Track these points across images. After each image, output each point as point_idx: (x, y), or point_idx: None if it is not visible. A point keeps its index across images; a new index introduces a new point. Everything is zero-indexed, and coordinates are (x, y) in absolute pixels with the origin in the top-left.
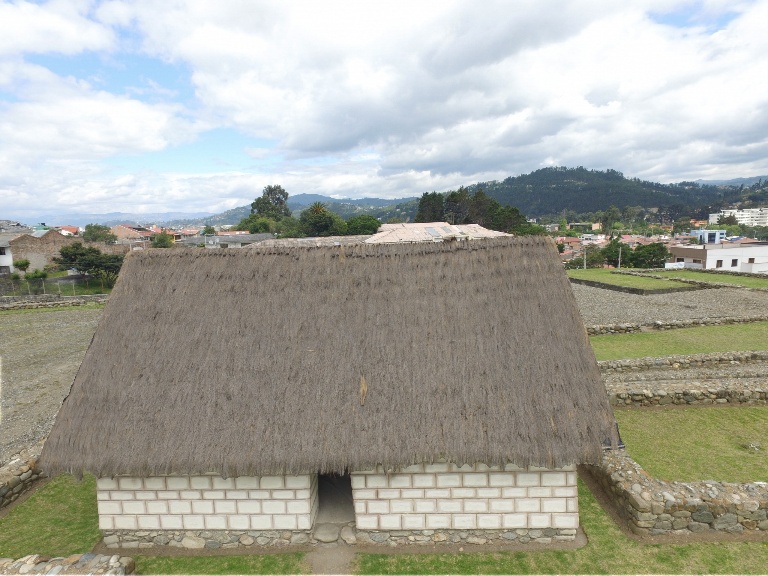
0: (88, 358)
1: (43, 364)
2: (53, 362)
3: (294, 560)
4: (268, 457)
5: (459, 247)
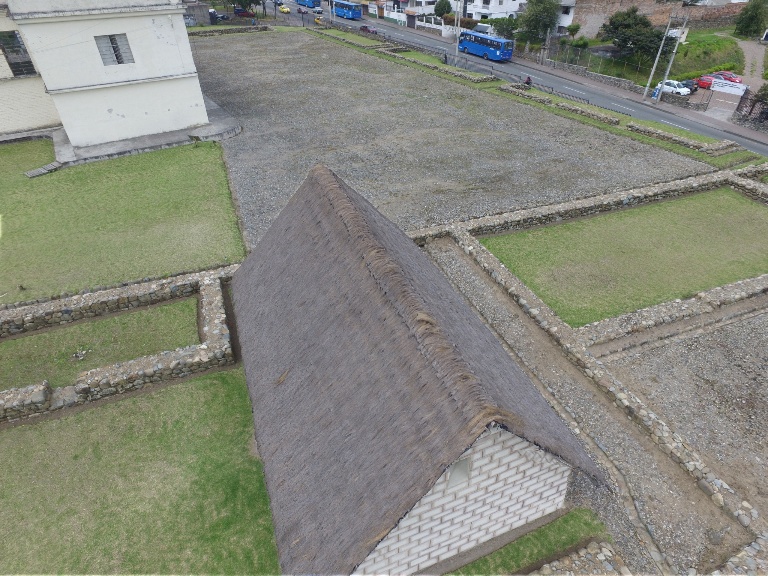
0: None
1: (429, 171)
2: (435, 172)
3: None
4: None
5: (416, 334)
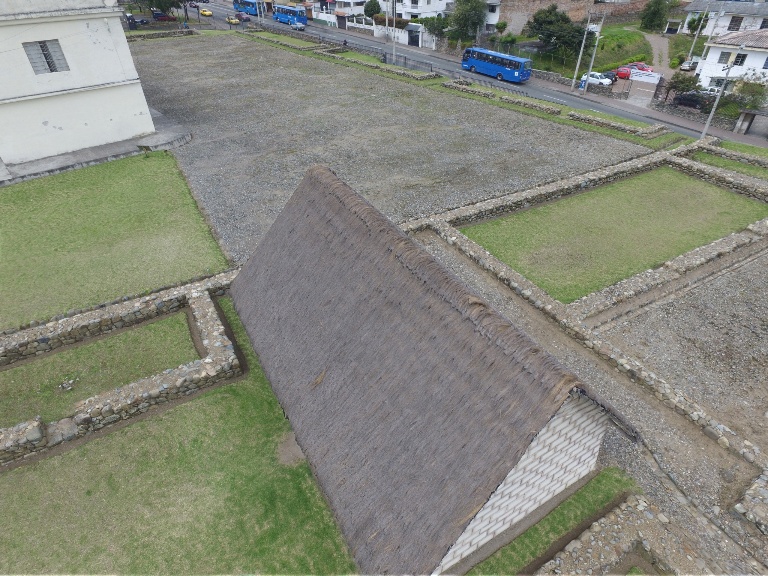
0: (263, 240)
1: (394, 168)
2: (400, 168)
3: (286, 429)
4: (269, 372)
5: (471, 317)
